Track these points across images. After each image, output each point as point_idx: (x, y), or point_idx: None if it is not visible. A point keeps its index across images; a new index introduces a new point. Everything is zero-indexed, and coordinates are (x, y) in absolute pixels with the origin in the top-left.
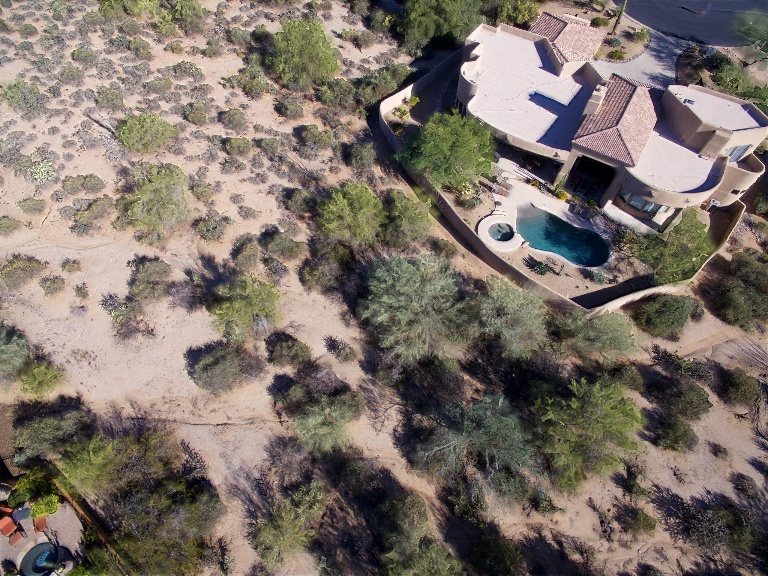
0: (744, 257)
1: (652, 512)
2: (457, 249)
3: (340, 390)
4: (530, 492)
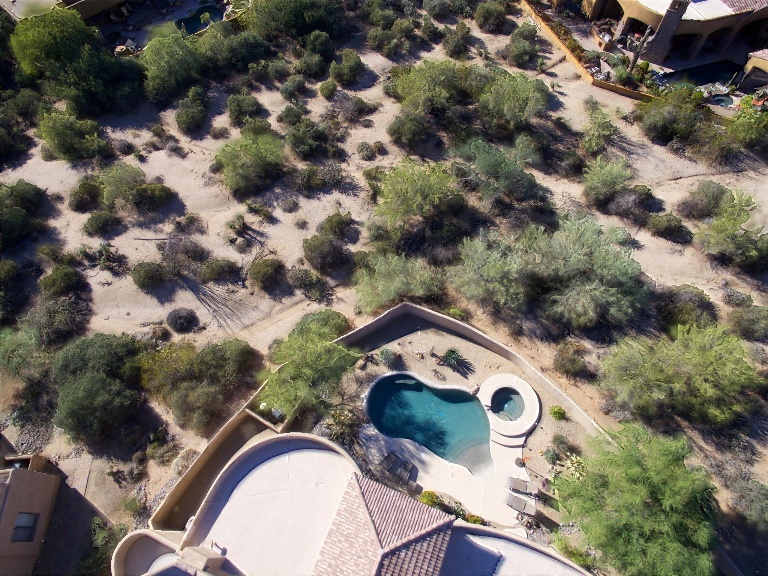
0: (208, 402)
1: (363, 182)
2: (554, 378)
3: (609, 202)
4: (454, 162)
